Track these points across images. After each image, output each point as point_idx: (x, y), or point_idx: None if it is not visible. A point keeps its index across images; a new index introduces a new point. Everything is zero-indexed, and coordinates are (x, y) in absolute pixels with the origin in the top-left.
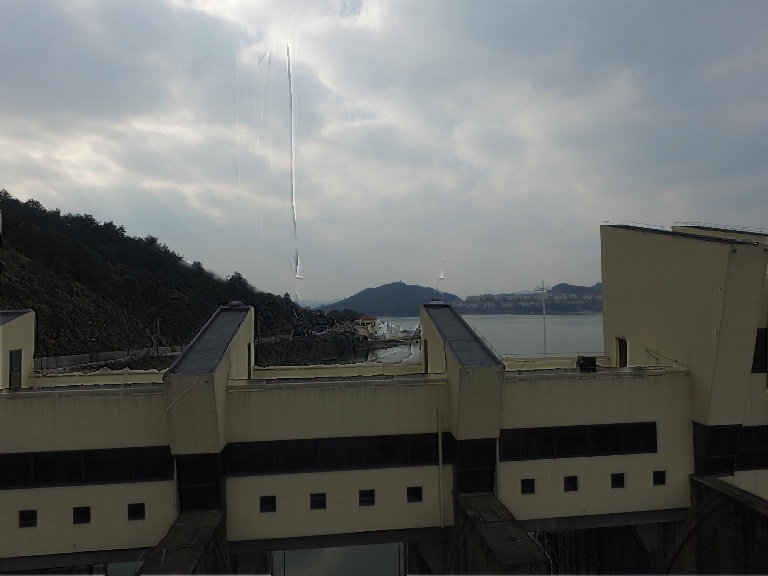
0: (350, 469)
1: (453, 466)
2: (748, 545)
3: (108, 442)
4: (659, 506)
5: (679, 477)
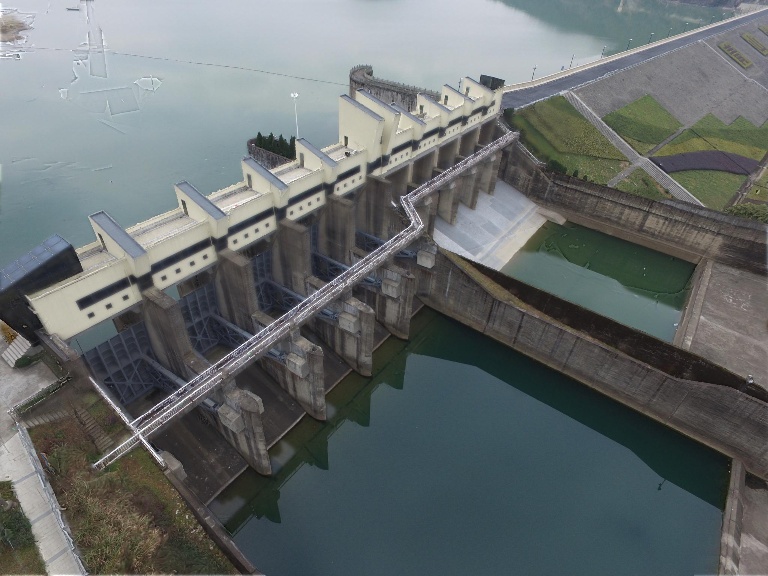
0: (306, 198)
1: (326, 190)
2: (377, 188)
3: (259, 211)
4: (360, 184)
5: (364, 176)
